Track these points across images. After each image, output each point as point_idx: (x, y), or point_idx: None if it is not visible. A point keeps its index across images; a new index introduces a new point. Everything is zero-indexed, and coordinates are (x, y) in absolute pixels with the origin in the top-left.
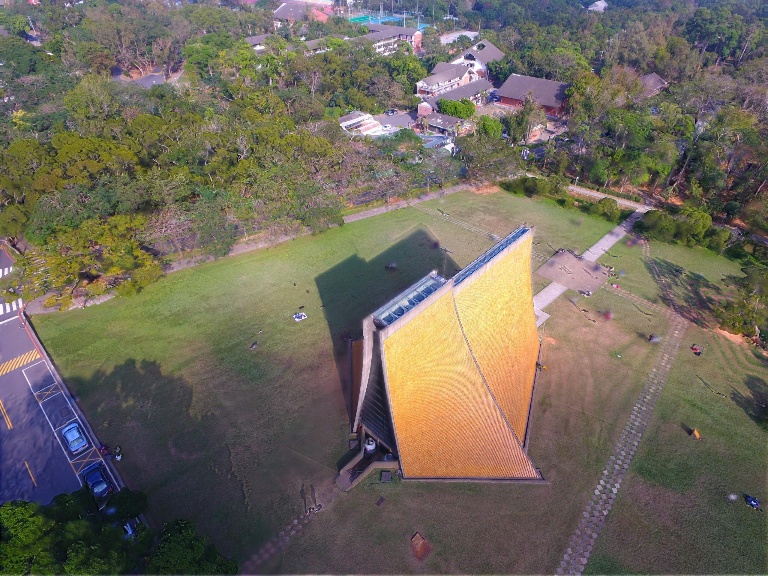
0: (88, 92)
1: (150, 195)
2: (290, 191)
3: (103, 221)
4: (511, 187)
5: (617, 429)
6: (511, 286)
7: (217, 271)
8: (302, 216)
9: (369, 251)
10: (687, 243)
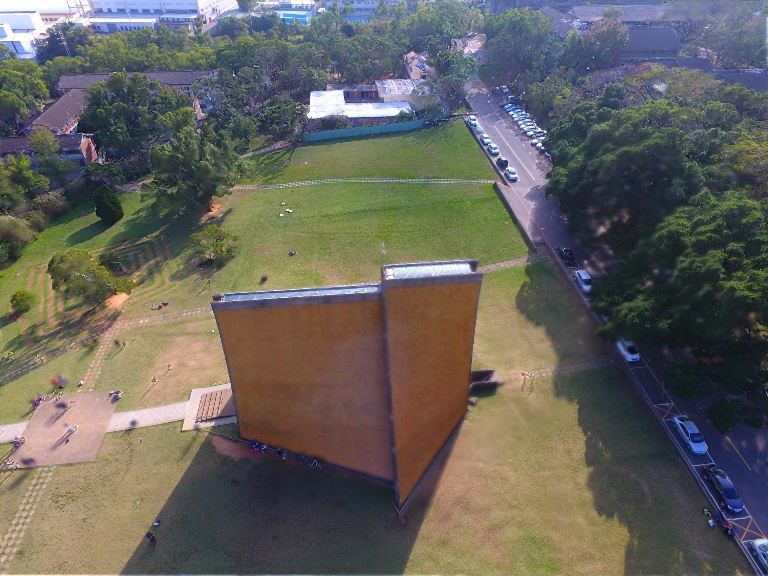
0: None
1: None
2: None
3: None
4: None
5: None
6: None
7: None
8: None
9: None
10: None
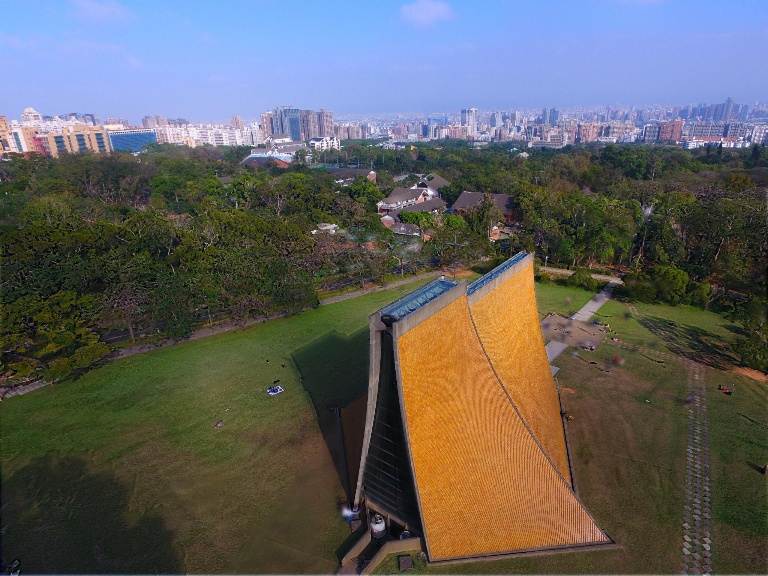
0: (47, 205)
1: (104, 272)
2: (261, 268)
3: (43, 298)
4: (485, 269)
5: (678, 474)
6: (521, 315)
7: (175, 354)
8: (274, 294)
9: (349, 327)
10: (670, 302)
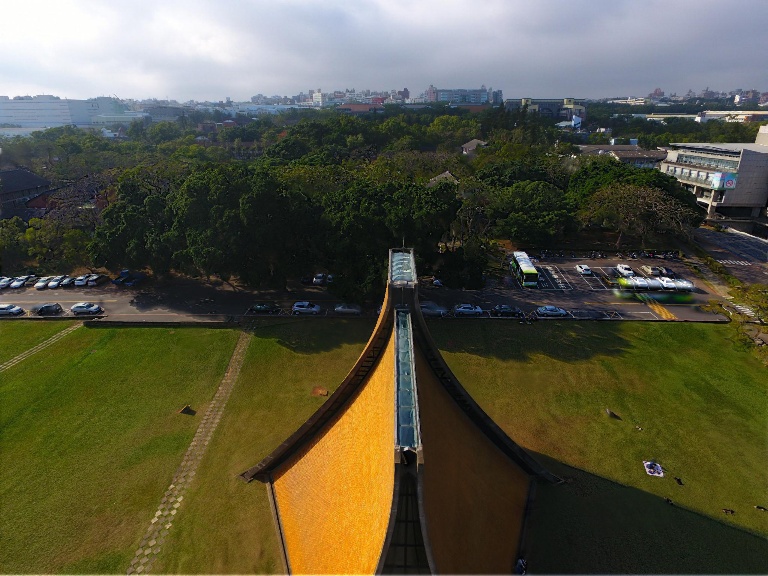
0: None
1: None
2: None
3: None
4: None
5: None
6: None
7: None
8: None
9: None
10: None
